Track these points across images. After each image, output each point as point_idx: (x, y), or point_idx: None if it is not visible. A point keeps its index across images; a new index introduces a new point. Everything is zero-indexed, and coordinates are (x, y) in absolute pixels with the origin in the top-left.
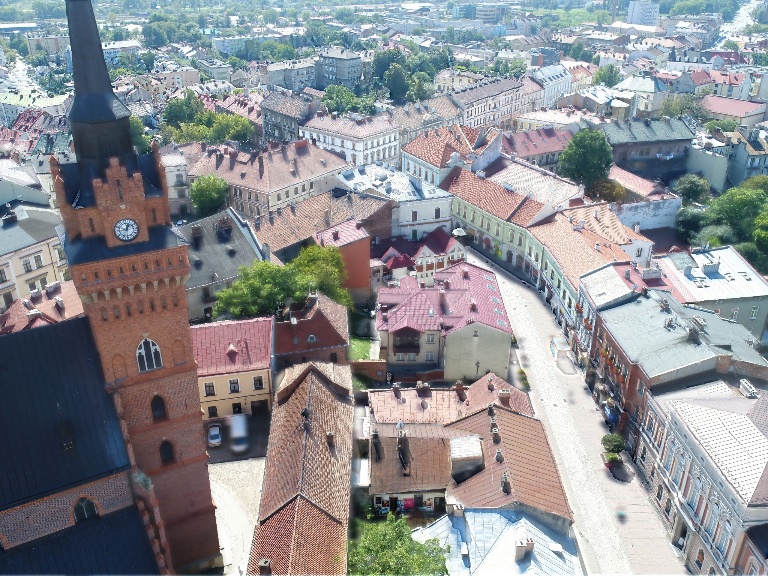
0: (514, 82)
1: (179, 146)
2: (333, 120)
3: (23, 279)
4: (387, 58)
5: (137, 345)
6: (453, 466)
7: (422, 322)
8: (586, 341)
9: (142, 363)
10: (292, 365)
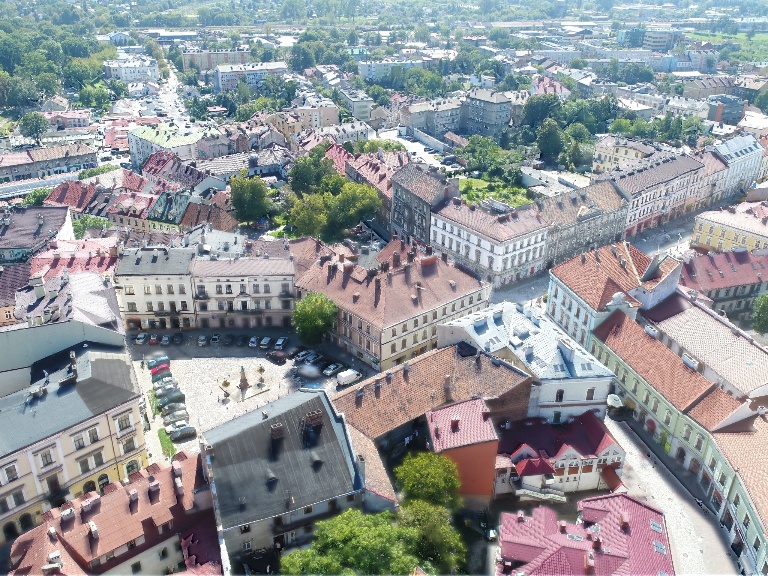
0: (693, 161)
1: (292, 242)
2: (471, 211)
3: (73, 457)
4: (541, 104)
5: None
6: None
7: None
8: None
9: None
10: None
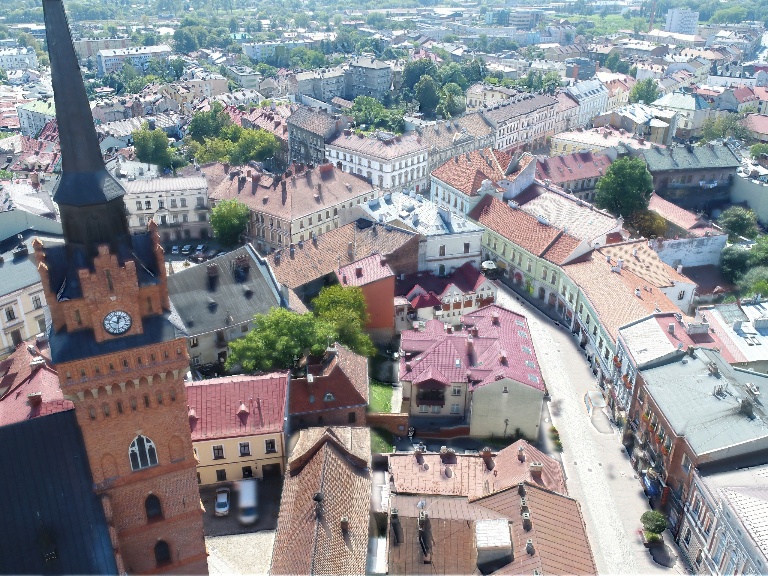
0: (548, 98)
1: (201, 166)
2: (360, 139)
3: (32, 316)
4: (418, 68)
5: (129, 443)
6: (478, 555)
7: (448, 373)
8: (624, 399)
9: (135, 461)
10: (307, 425)
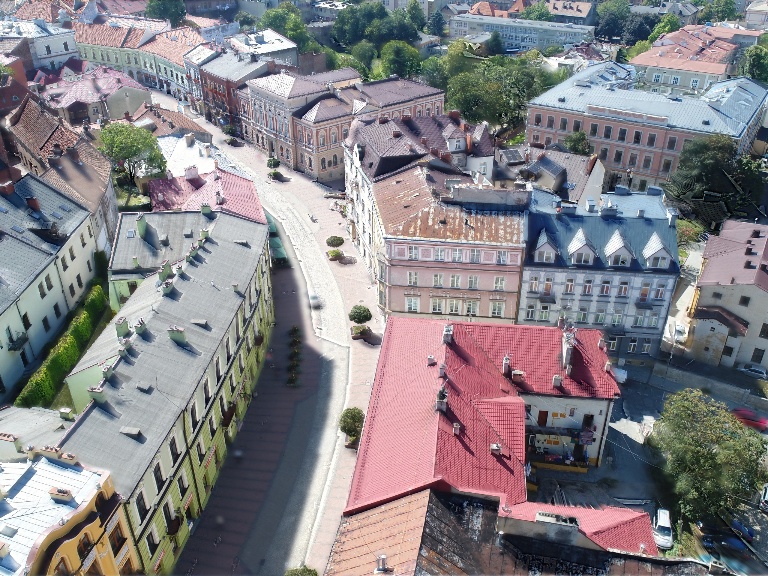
0: None
1: None
2: None
3: None
4: None
5: None
6: None
7: (86, 99)
8: (199, 93)
9: None
10: None
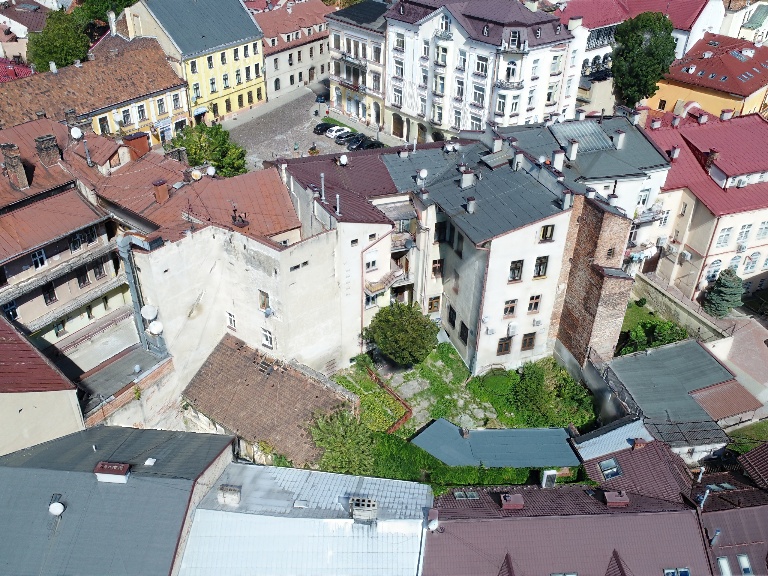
0: None
1: (326, 234)
2: None
3: None
4: None
5: None
6: None
7: None
8: None
9: None
10: None
